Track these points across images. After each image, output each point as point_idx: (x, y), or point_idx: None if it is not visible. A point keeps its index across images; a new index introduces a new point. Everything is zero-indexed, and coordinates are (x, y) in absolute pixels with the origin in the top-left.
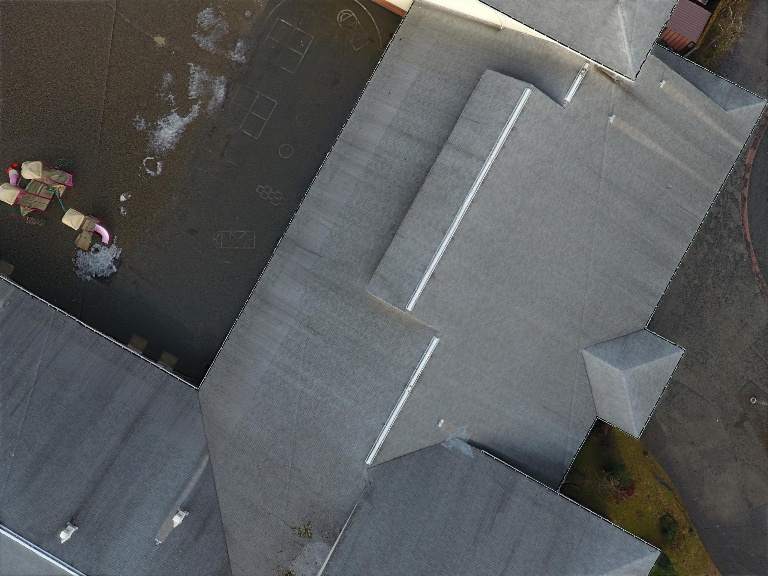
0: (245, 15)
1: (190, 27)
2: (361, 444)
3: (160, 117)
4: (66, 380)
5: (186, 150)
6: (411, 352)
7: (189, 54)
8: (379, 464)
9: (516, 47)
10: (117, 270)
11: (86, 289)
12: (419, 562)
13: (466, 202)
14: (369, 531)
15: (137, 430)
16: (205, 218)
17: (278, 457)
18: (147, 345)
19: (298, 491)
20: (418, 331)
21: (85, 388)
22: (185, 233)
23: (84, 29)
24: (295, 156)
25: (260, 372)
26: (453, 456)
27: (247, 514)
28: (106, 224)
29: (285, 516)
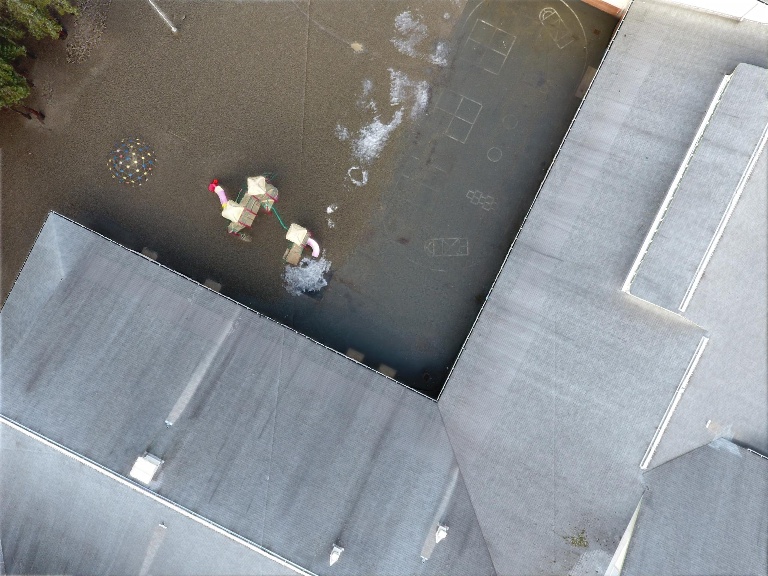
0: (444, 17)
1: (388, 32)
2: (633, 449)
3: (362, 125)
4: (307, 399)
5: (391, 158)
6: (678, 353)
7: (388, 60)
8: (653, 468)
9: (760, 39)
10: (328, 284)
11: (297, 305)
12: (709, 565)
13: (735, 199)
14: (655, 537)
15: (385, 446)
16: (415, 226)
17: (539, 466)
18: (364, 359)
19: (566, 500)
20: (684, 332)
21: (327, 406)
22: (396, 243)
23: (278, 39)
24: (504, 159)
25: (507, 381)
26: (722, 456)
27: (510, 526)
28: (314, 237)
29: (555, 526)
